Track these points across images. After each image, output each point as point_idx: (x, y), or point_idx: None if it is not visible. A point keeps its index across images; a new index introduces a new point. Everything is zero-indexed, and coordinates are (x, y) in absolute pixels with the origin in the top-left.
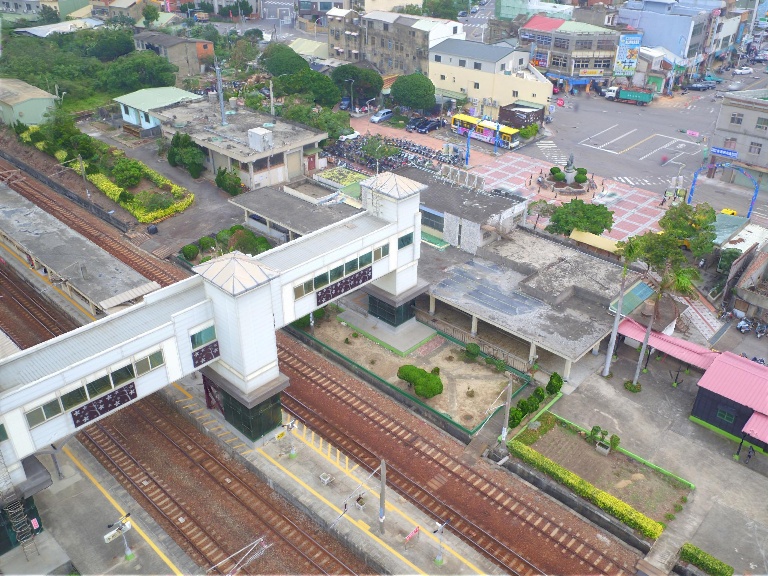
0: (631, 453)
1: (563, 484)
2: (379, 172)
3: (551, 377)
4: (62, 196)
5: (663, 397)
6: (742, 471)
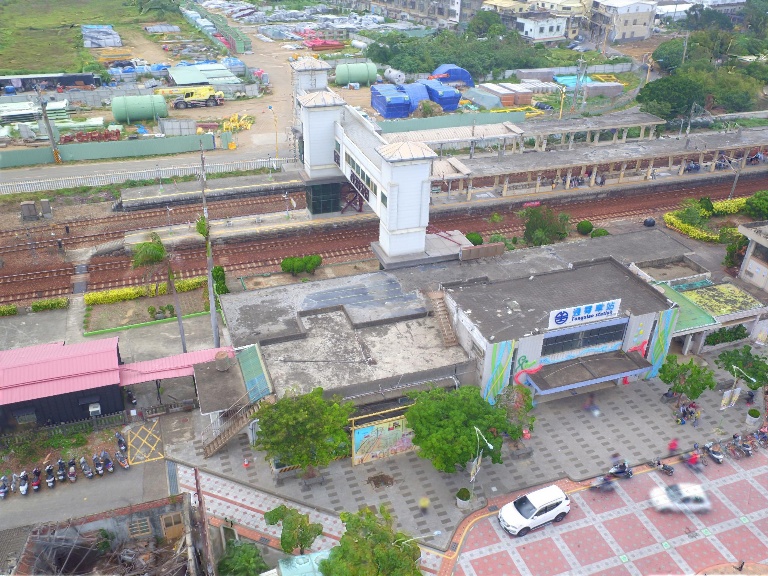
0: None
1: None
2: None
3: None
4: None
5: None
6: None
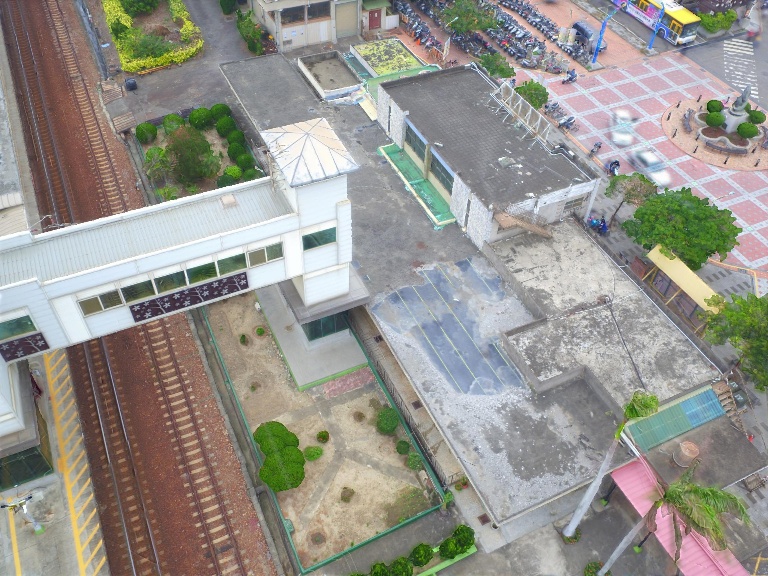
0: None
1: None
2: (463, 50)
3: (456, 531)
4: (76, 7)
5: None
6: None
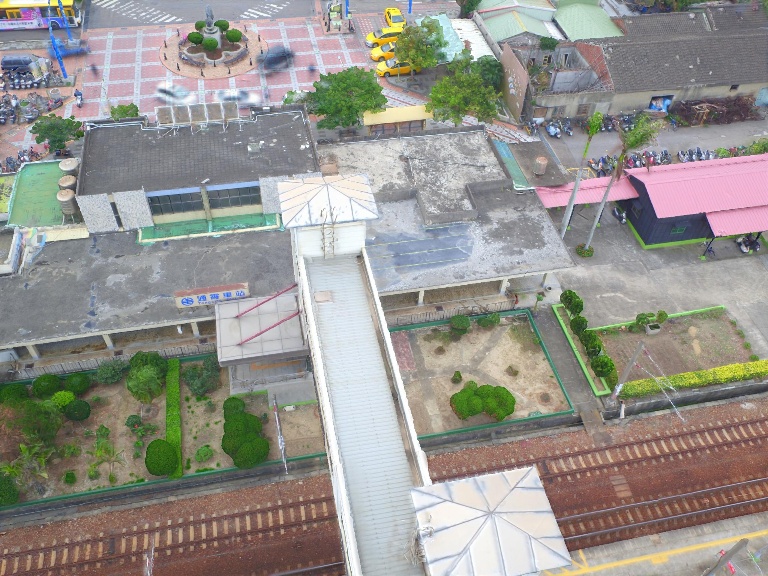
0: (669, 315)
1: (681, 388)
2: None
3: (568, 298)
4: None
5: (608, 243)
6: (718, 267)
